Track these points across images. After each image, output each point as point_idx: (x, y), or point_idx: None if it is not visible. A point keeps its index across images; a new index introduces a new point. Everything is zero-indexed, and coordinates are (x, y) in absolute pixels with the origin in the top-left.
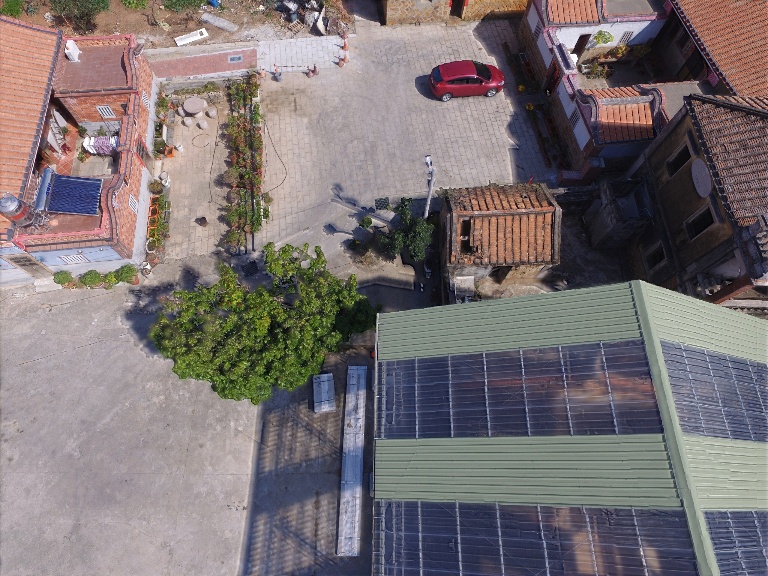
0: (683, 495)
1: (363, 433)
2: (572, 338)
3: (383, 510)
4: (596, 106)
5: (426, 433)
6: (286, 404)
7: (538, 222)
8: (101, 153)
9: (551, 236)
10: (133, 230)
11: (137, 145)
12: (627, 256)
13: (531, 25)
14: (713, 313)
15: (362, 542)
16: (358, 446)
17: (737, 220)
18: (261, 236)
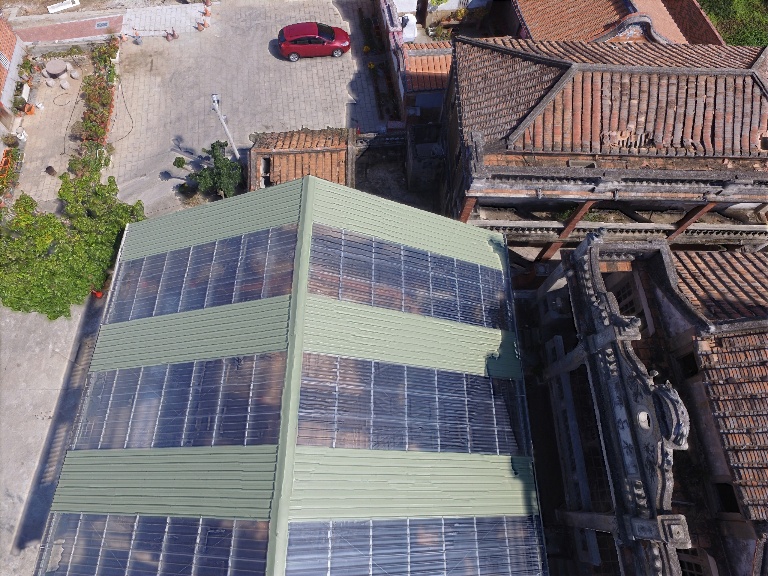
0: (289, 339)
1: None
2: (253, 227)
3: (92, 380)
4: (403, 57)
5: (136, 315)
6: None
7: (333, 159)
8: None
9: (345, 172)
10: None
11: None
12: (439, 197)
13: None
14: (401, 212)
15: None
16: None
17: (465, 142)
18: None
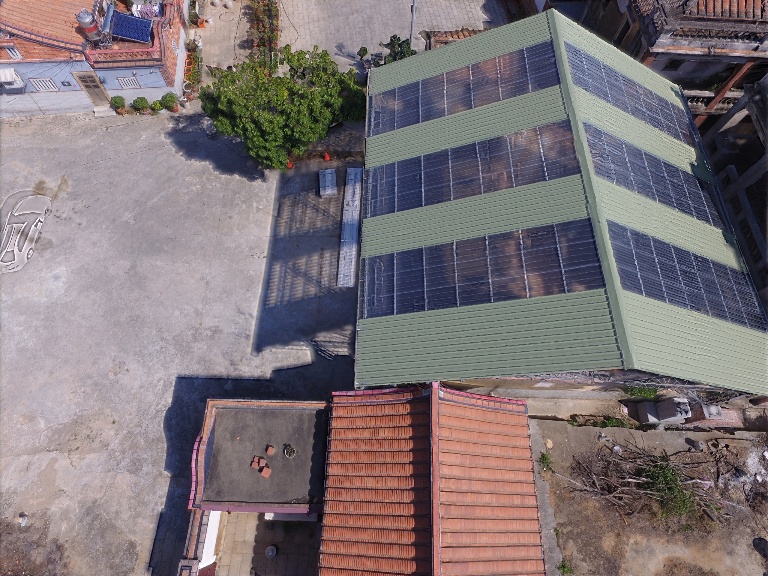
0: (569, 111)
1: (359, 210)
2: (505, 50)
3: (370, 173)
4: None
5: (402, 125)
6: (297, 192)
7: None
8: None
9: None
10: (175, 67)
11: (177, 6)
12: None
13: None
14: (612, 50)
15: (357, 279)
16: (354, 218)
17: (642, 13)
18: None
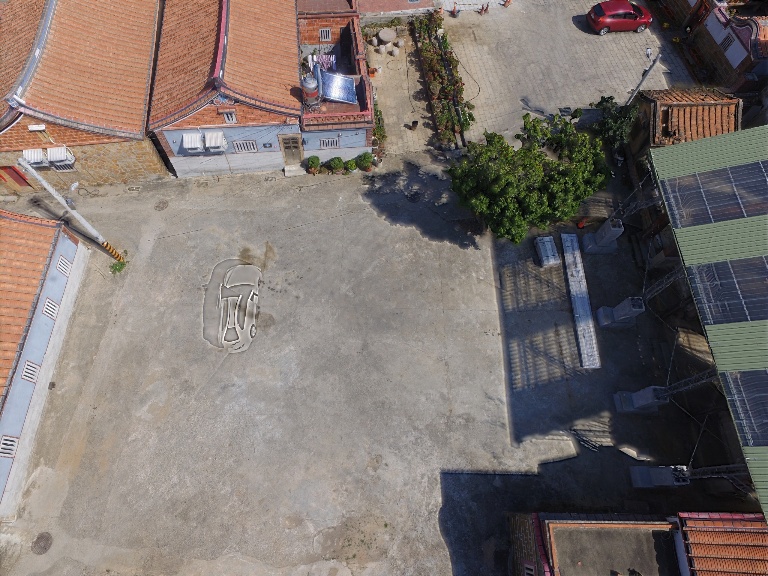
0: None
1: (585, 281)
2: None
3: (696, 271)
4: (757, 26)
5: (721, 218)
6: (515, 261)
7: (724, 112)
8: None
9: (734, 124)
10: None
11: None
12: None
13: None
14: None
15: (601, 359)
16: (583, 290)
17: None
18: (470, 134)
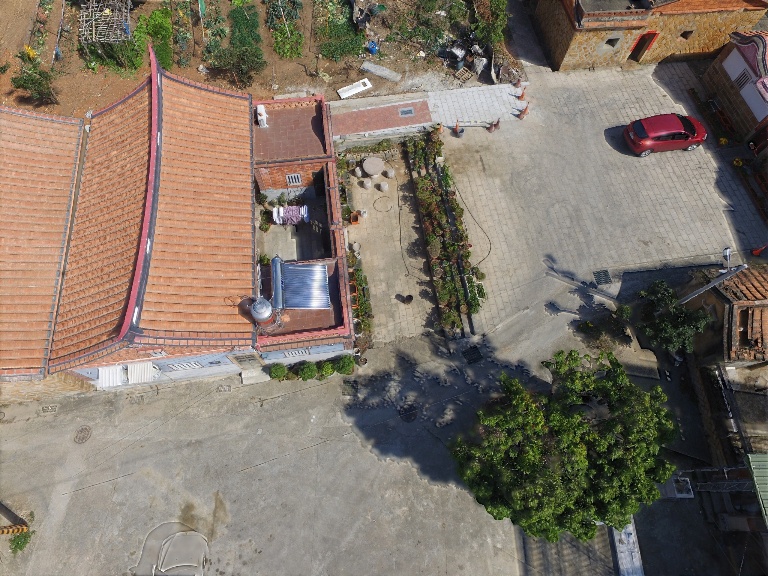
0: None
1: (639, 551)
2: None
3: None
4: None
5: None
6: None
7: None
8: (288, 223)
9: None
10: None
11: None
12: None
13: (729, 72)
14: None
15: None
16: (637, 567)
17: None
18: (479, 317)
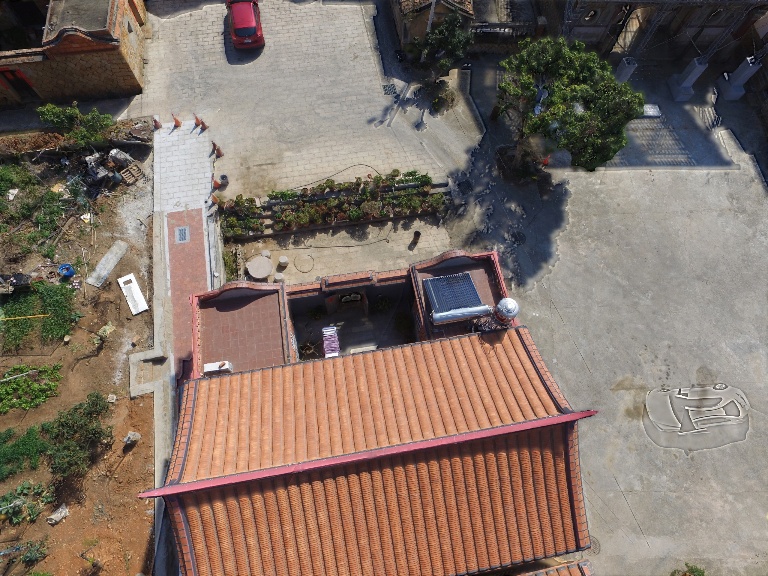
0: None
1: None
2: None
3: None
4: None
5: None
6: None
7: None
8: None
9: None
10: None
11: None
12: None
13: None
14: None
15: None
16: None
17: None
18: (434, 178)
